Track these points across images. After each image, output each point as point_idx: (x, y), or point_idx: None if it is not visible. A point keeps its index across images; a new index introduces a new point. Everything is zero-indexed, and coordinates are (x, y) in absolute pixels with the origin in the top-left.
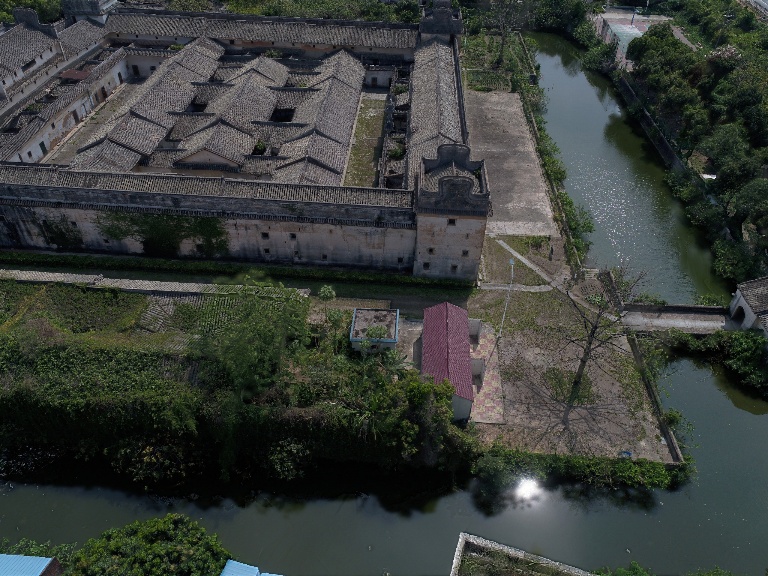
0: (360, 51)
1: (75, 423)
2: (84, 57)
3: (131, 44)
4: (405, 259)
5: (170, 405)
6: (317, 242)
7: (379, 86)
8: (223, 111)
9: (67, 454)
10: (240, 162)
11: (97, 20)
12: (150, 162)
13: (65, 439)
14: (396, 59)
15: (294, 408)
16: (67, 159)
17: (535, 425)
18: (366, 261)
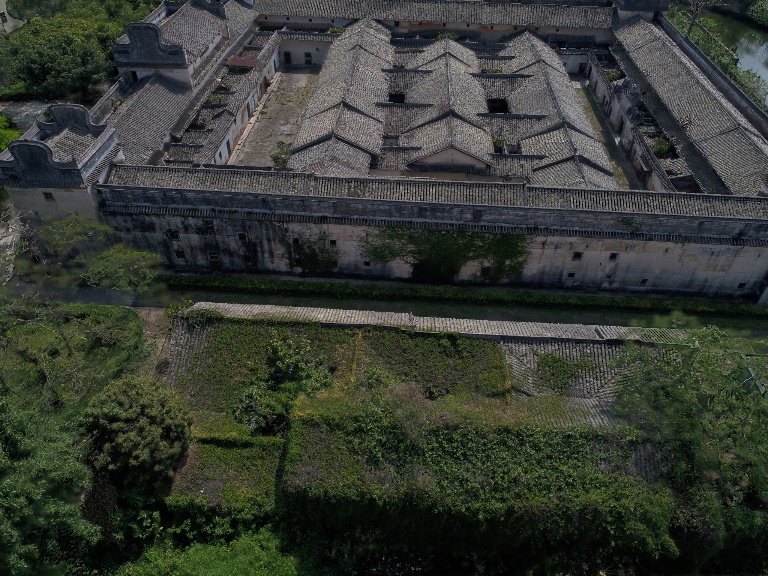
0: (545, 32)
1: (465, 530)
2: (241, 42)
3: (284, 27)
4: (749, 284)
5: (636, 514)
6: (642, 264)
7: (567, 72)
8: (443, 101)
9: (436, 567)
10: (491, 162)
11: (244, 0)
12: (379, 163)
13: (432, 546)
14: (587, 41)
15: None
16: (256, 160)
17: None
18: (696, 286)
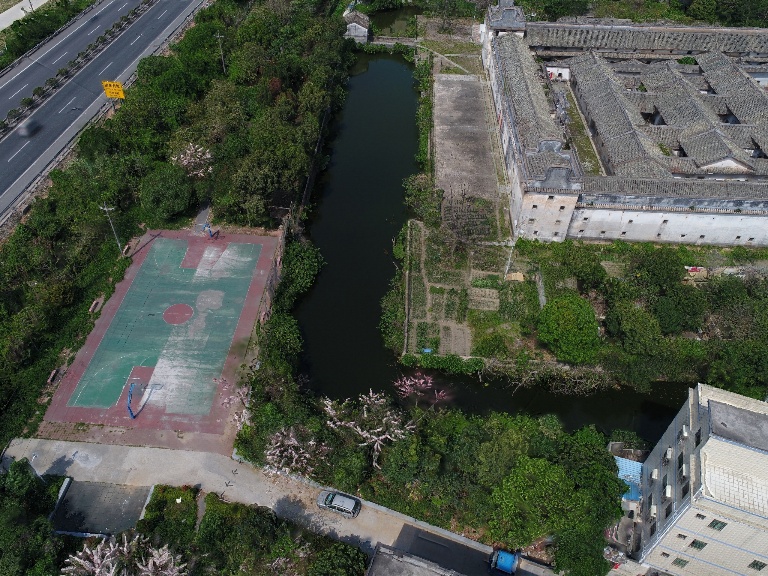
0: None
1: None
2: None
3: None
4: None
5: None
6: None
7: None
8: None
9: None
10: None
11: None
12: None
13: None
14: None
15: (543, 4)
16: None
17: (461, 25)
18: None
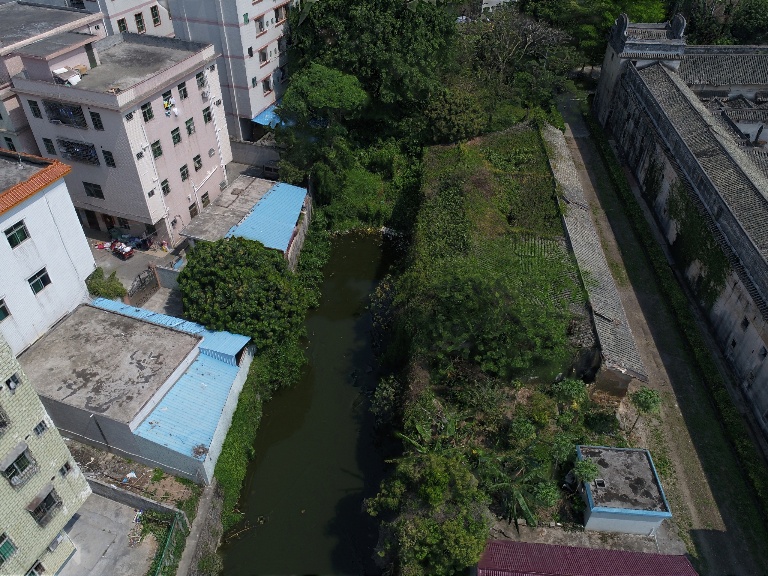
0: None
1: None
2: None
3: None
4: None
5: None
6: None
7: None
8: None
9: None
10: None
11: None
12: None
13: None
14: None
15: (424, 372)
16: None
17: None
18: None
